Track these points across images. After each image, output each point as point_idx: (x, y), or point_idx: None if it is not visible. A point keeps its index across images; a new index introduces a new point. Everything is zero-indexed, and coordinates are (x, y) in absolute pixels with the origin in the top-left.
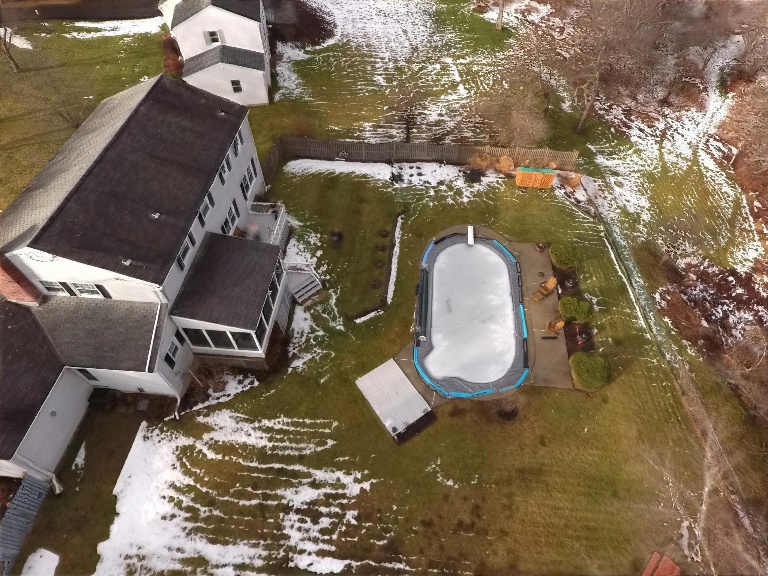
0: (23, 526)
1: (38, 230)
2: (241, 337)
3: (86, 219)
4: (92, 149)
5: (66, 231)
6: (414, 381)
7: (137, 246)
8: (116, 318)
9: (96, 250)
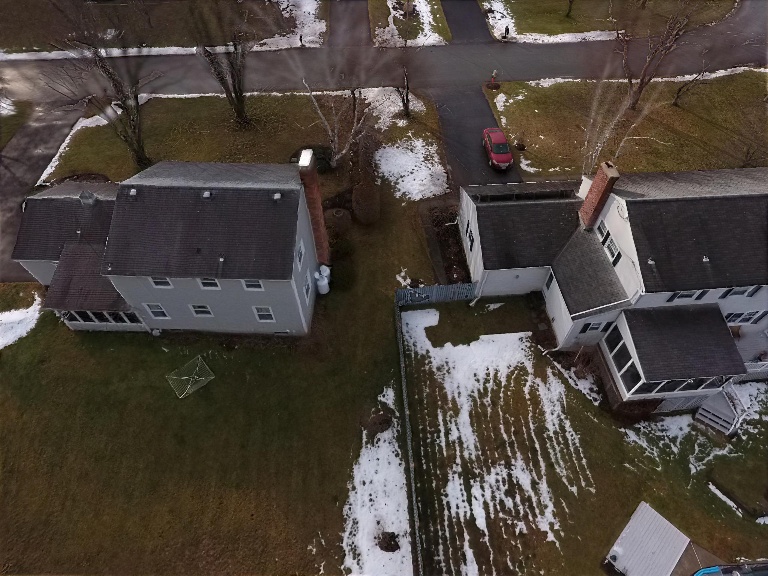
0: (448, 297)
1: (641, 199)
2: (632, 373)
3: (669, 219)
4: (734, 188)
5: (651, 213)
6: (677, 573)
7: (669, 261)
8: (601, 277)
9: (648, 238)
